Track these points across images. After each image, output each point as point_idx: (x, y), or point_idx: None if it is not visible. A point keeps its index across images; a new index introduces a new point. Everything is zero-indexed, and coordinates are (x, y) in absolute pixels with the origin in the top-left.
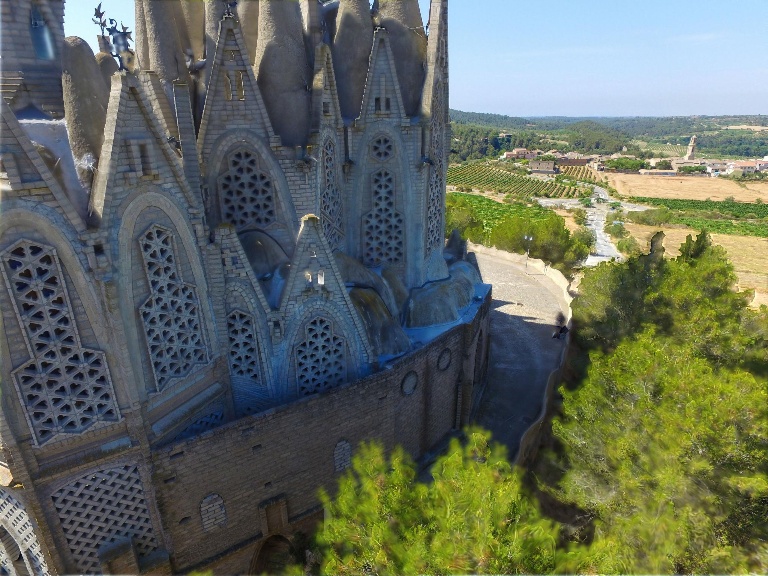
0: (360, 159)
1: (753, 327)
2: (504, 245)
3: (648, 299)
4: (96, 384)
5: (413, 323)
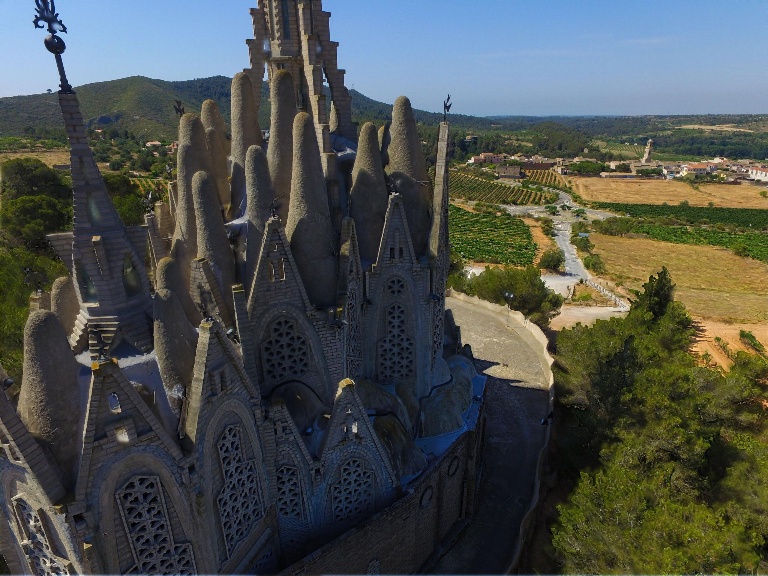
0: (376, 296)
1: (710, 387)
2: (485, 294)
3: (624, 399)
4: (182, 568)
5: (424, 434)
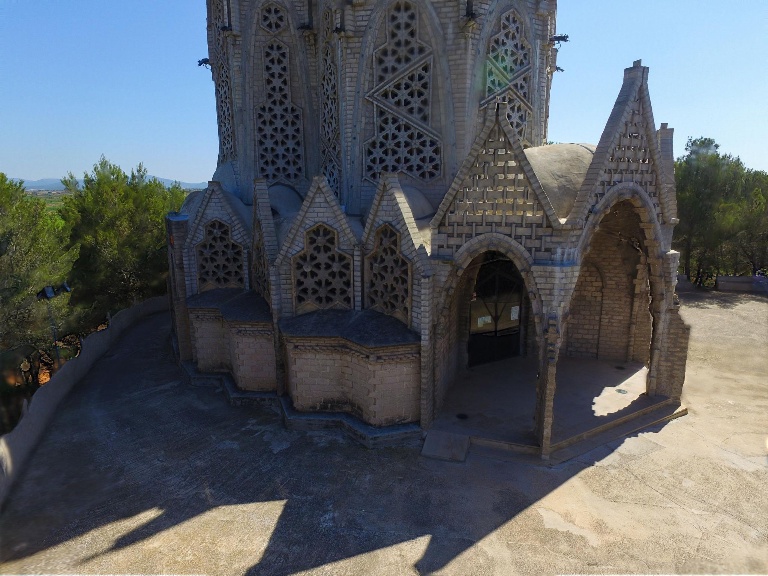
0: None
1: None
2: None
3: None
4: None
5: None
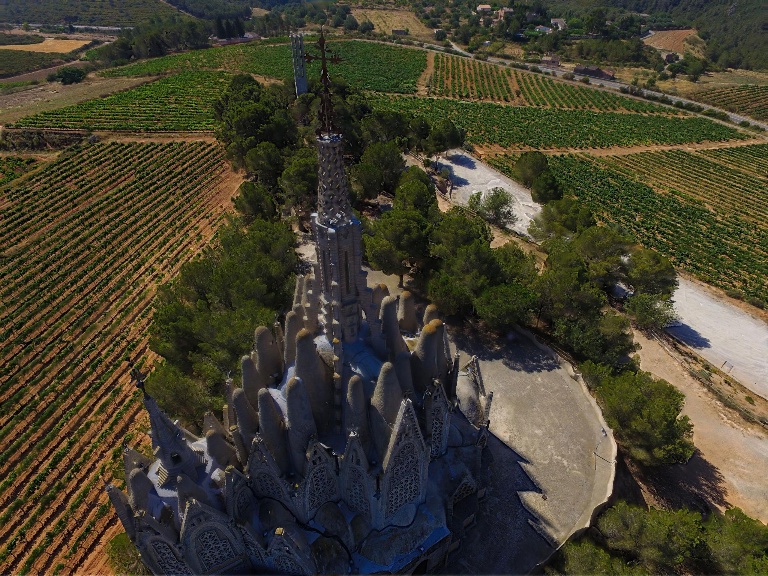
0: (345, 470)
1: None
2: (606, 402)
3: None
4: (184, 567)
5: (362, 554)
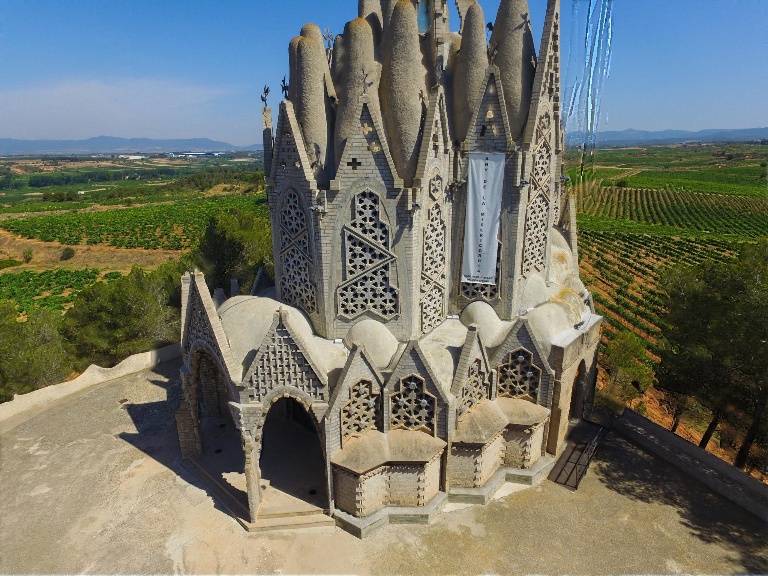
0: None
1: None
2: None
3: None
4: None
5: None
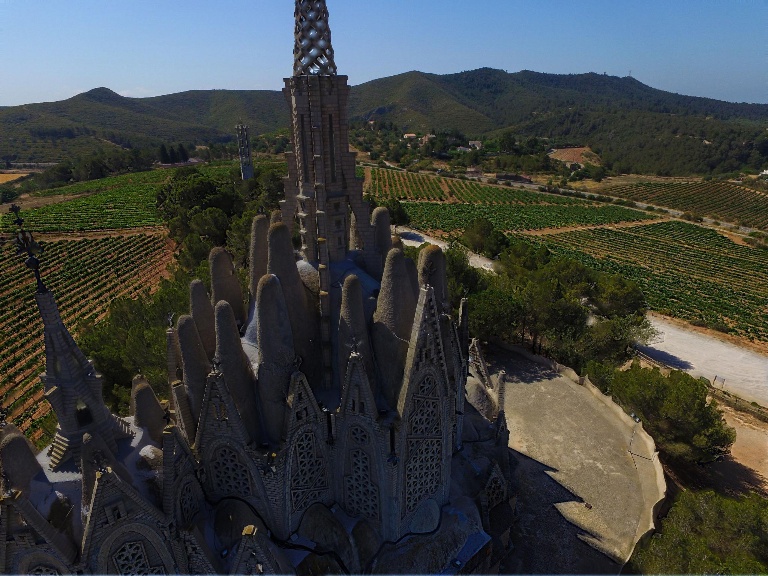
0: (342, 437)
1: None
2: (623, 398)
3: None
4: None
5: None
